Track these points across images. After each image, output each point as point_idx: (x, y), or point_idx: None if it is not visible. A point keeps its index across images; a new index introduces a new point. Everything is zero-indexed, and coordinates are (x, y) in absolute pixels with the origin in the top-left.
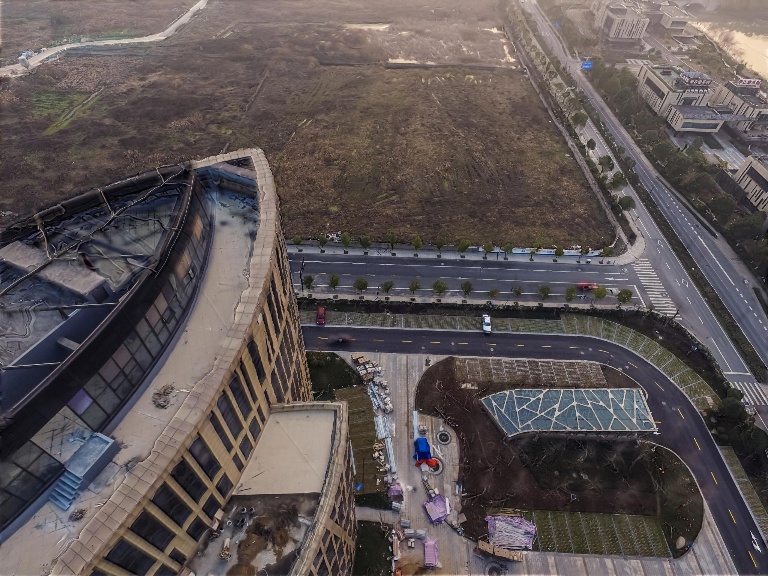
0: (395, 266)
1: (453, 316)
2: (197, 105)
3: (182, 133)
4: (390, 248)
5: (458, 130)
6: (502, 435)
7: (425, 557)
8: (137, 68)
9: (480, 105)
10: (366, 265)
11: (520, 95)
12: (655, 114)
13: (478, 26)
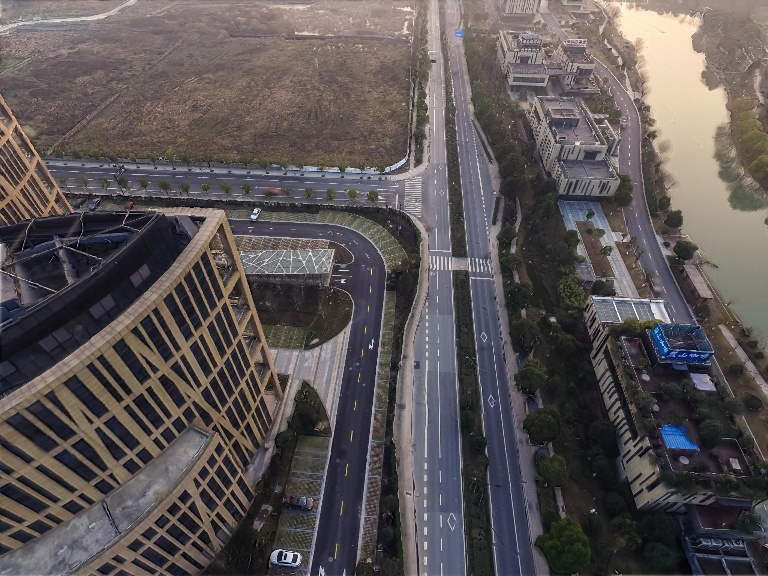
0: (209, 179)
1: (233, 210)
2: (105, 66)
3: (84, 87)
4: (211, 167)
5: (320, 85)
6: None
7: None
8: (71, 40)
9: (352, 67)
10: (186, 178)
11: (393, 59)
12: (501, 73)
13: (392, 5)
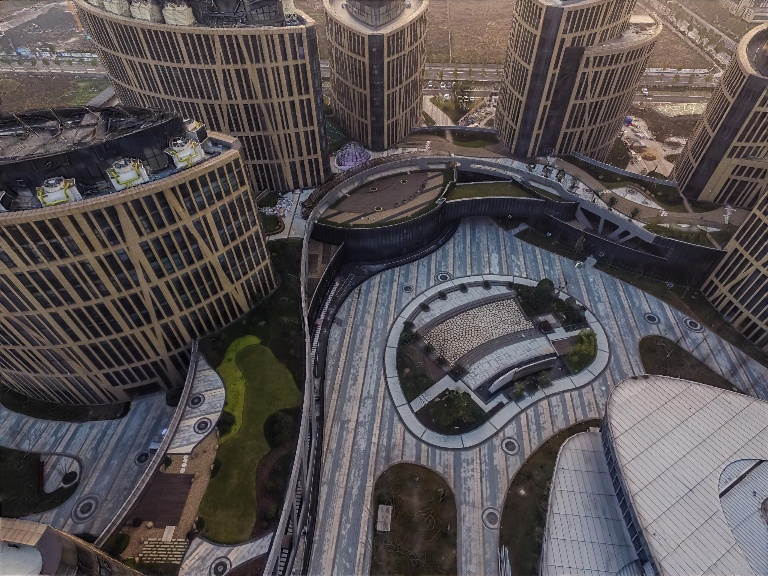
0: None
1: None
2: None
3: None
4: None
5: None
6: (666, 119)
7: (641, 144)
8: None
9: None
10: None
11: None
12: (733, 16)
13: None
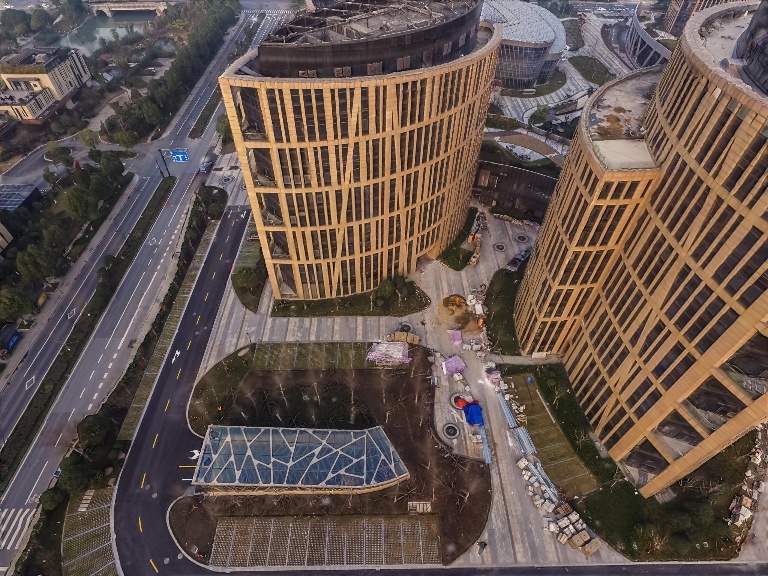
0: None
1: None
2: None
3: None
4: None
5: None
6: None
7: None
8: None
9: None
10: None
11: None
12: None
13: None
